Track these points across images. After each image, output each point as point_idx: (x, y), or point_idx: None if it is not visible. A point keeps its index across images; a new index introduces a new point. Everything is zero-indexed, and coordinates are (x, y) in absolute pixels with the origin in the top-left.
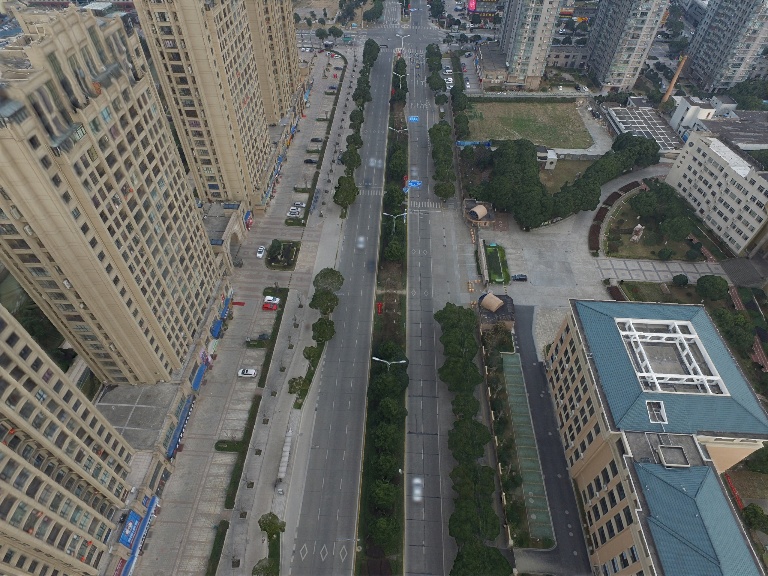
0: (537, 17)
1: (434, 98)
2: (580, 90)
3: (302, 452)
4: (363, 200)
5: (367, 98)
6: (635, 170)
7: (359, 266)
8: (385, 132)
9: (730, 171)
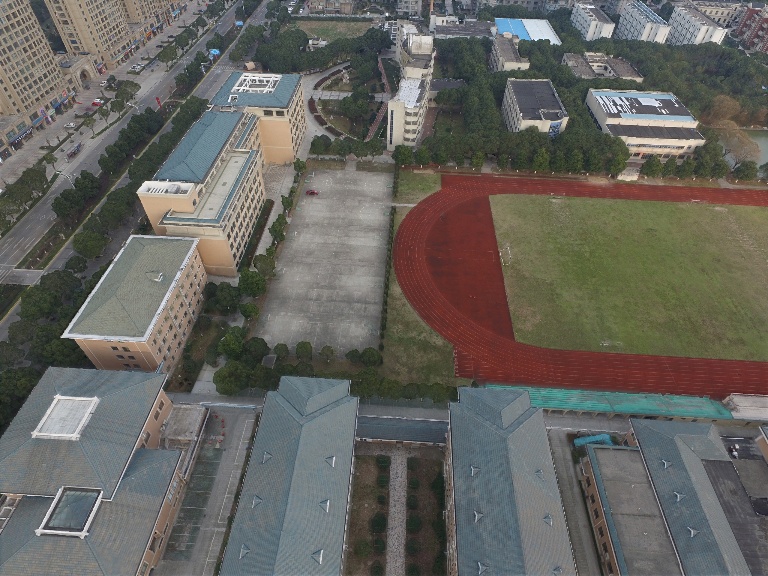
0: None
1: None
2: None
3: (86, 152)
4: None
5: (215, 13)
6: (381, 54)
7: (163, 91)
8: (223, 34)
9: None
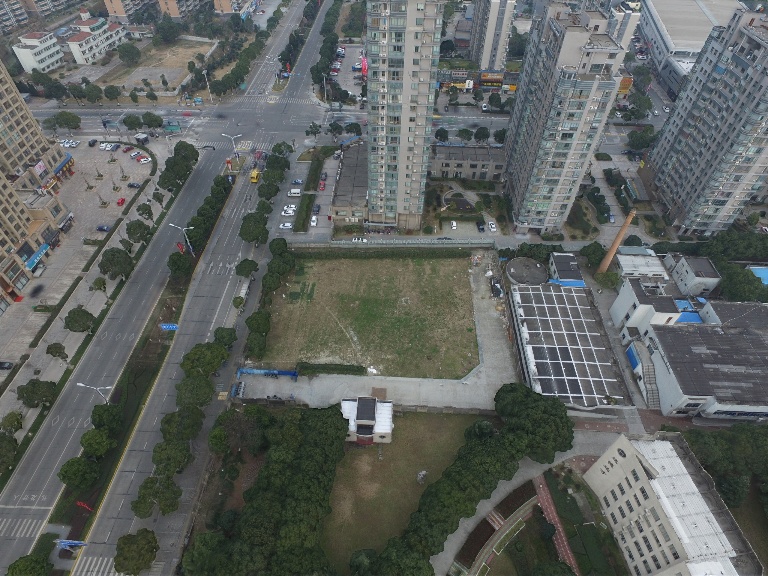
0: (394, 139)
1: (252, 250)
2: (483, 230)
3: None
4: None
5: (119, 271)
6: None
7: None
8: (135, 338)
9: None
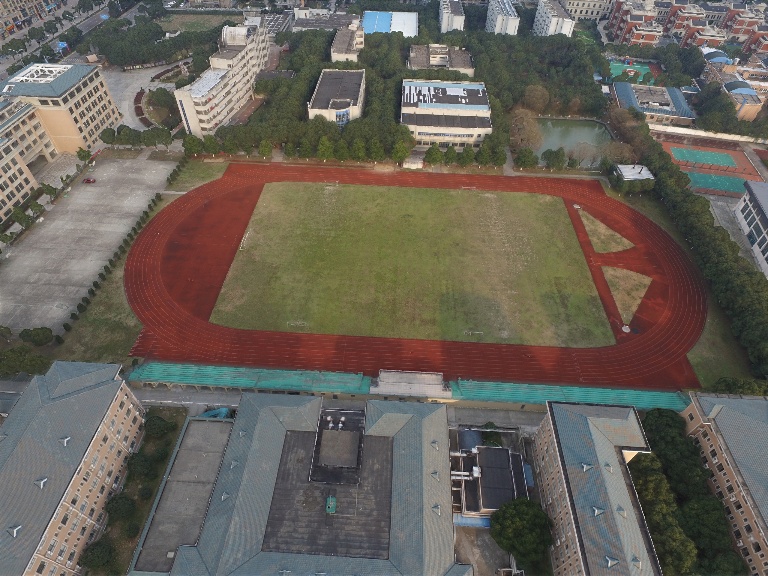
0: None
1: None
2: None
3: None
4: None
5: (86, 6)
6: None
7: None
8: (91, 28)
9: None
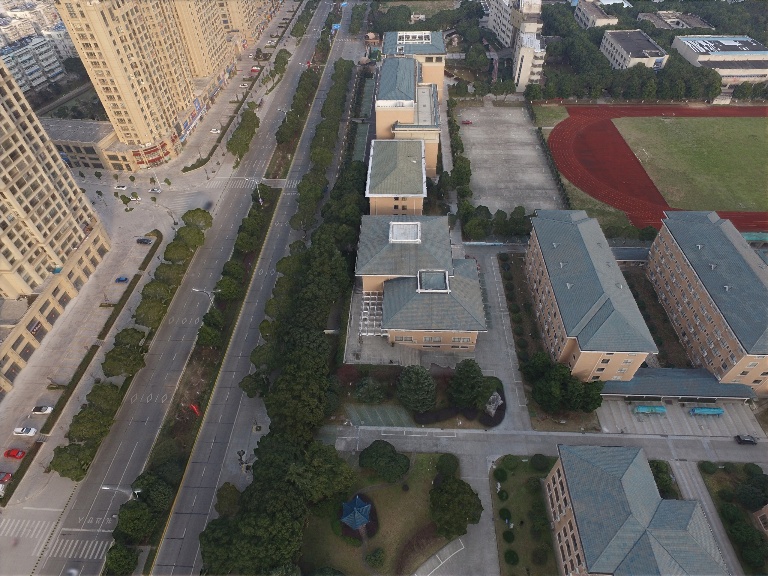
0: None
1: None
2: None
3: (267, 103)
4: (309, 40)
5: None
6: None
7: (303, 59)
8: None
9: (503, 5)
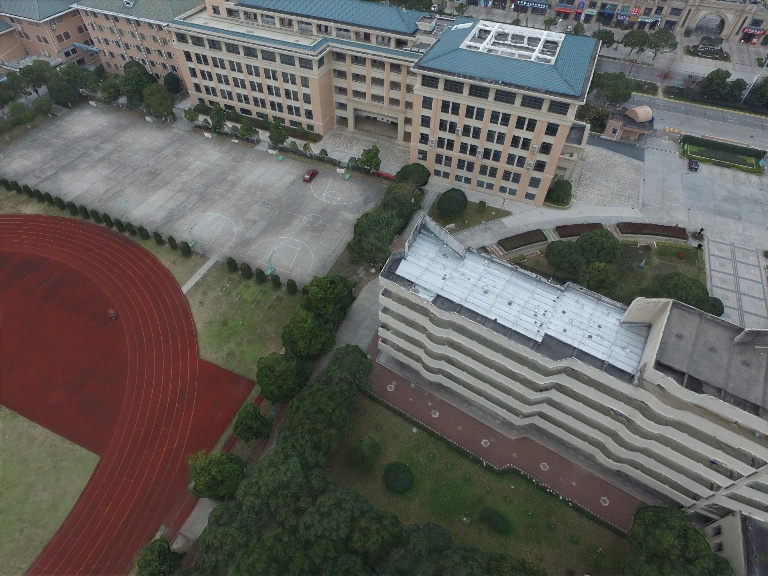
0: None
1: None
2: None
3: None
4: None
5: None
6: None
7: None
8: None
9: None
